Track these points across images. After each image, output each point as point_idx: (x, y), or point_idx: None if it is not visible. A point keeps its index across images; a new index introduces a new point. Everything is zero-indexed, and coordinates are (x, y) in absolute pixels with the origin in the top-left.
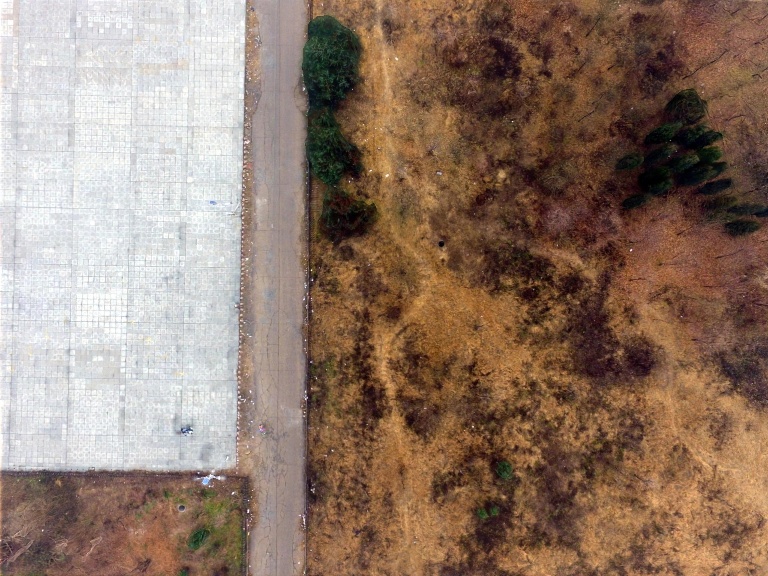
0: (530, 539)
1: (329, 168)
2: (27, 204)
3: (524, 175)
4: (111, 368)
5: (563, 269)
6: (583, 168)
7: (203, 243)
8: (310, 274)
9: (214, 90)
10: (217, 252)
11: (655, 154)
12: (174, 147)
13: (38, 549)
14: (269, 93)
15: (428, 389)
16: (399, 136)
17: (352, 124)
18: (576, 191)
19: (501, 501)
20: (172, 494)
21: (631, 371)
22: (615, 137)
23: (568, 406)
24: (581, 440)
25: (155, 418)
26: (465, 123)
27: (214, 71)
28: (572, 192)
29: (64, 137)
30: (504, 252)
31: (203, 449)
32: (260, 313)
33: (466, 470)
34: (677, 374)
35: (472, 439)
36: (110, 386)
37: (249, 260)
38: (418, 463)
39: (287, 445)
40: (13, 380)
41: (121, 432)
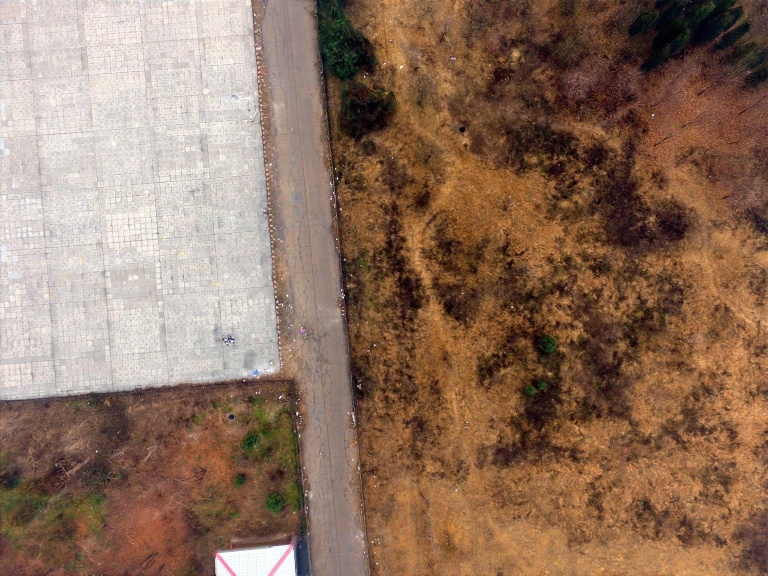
0: (580, 413)
1: (345, 57)
2: (48, 132)
3: (538, 51)
4: (147, 286)
5: (587, 141)
6: (597, 38)
7: (225, 153)
8: (335, 173)
9: None
10: (240, 160)
11: (669, 10)
12: (187, 60)
13: (94, 470)
14: None
15: (464, 274)
16: (409, 26)
17: (361, 19)
18: (592, 62)
19: (548, 378)
20: (220, 404)
21: (665, 236)
22: (626, 4)
23: (605, 277)
24: (621, 310)
25: (196, 331)
26: (474, 6)
27: None
28: (588, 63)
29: (77, 61)
30: (526, 131)
31: (246, 357)
32: (289, 217)
33: (510, 350)
34: (711, 234)
35: (512, 319)
36: (148, 304)
37: (273, 165)
38: (461, 349)
39: (329, 345)
40: (52, 307)
41: (164, 348)
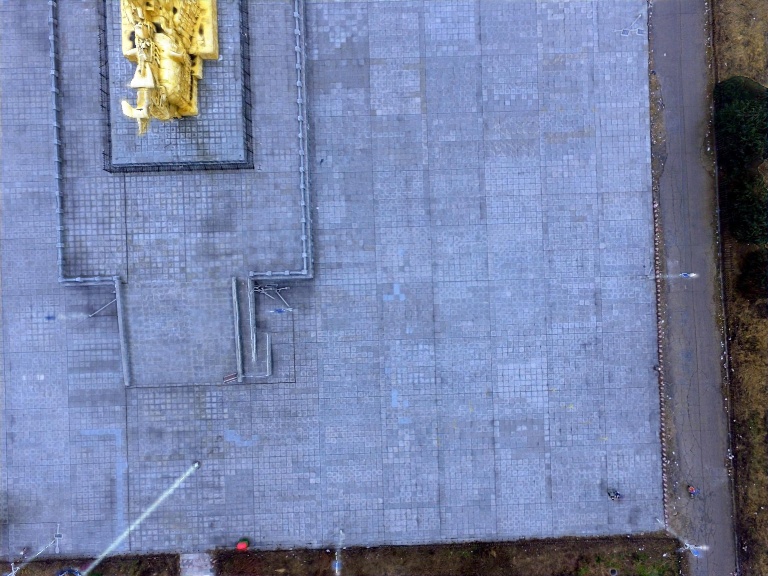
0: None
1: None
2: (444, 279)
3: None
4: (535, 437)
5: None
6: None
7: (619, 308)
8: (728, 333)
9: (621, 155)
10: (633, 316)
11: None
12: (585, 214)
13: None
14: (675, 155)
15: None
16: None
17: None
18: None
19: None
20: (603, 559)
21: None
22: None
23: None
24: None
25: (581, 484)
26: None
27: (621, 136)
28: None
29: (476, 210)
30: None
31: (631, 512)
32: (678, 374)
33: None
34: None
35: None
36: (535, 455)
37: (665, 322)
38: None
39: (714, 504)
40: (440, 454)
41: (549, 500)
